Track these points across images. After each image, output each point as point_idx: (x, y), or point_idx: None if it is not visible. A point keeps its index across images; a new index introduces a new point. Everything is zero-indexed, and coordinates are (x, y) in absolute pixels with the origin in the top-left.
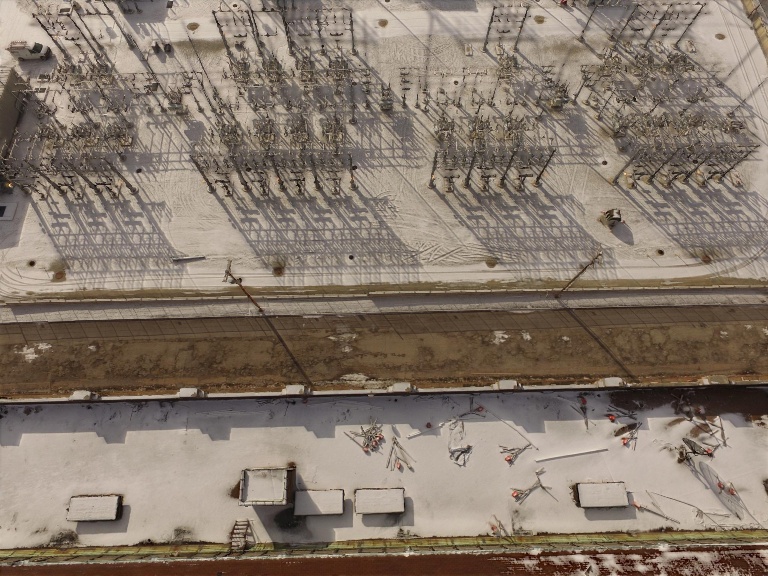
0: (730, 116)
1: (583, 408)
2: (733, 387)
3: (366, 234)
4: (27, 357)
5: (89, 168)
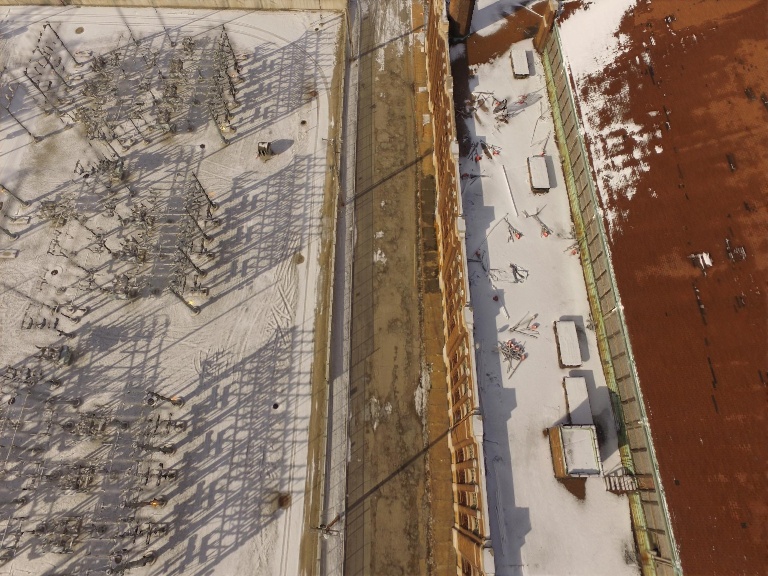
0: (174, 45)
1: (472, 176)
2: None
3: (248, 388)
4: None
5: None
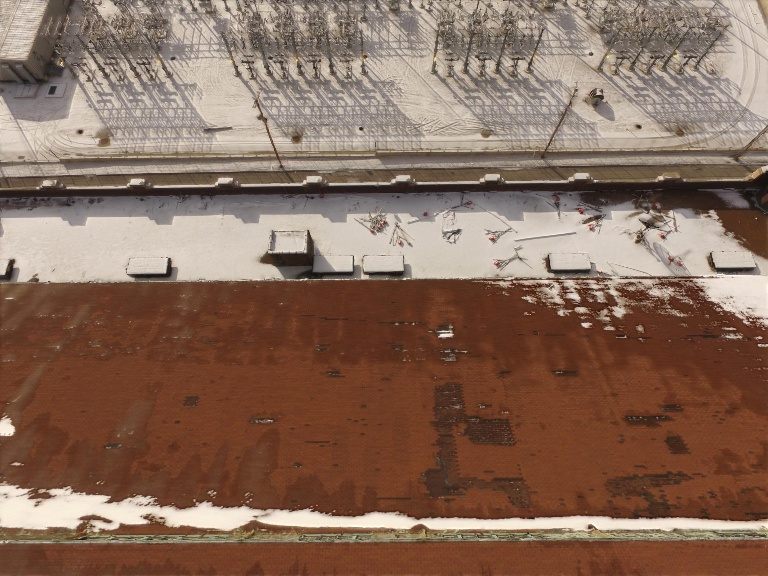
0: (708, 16)
1: (556, 203)
2: (686, 188)
3: (374, 110)
4: None
5: (129, 56)
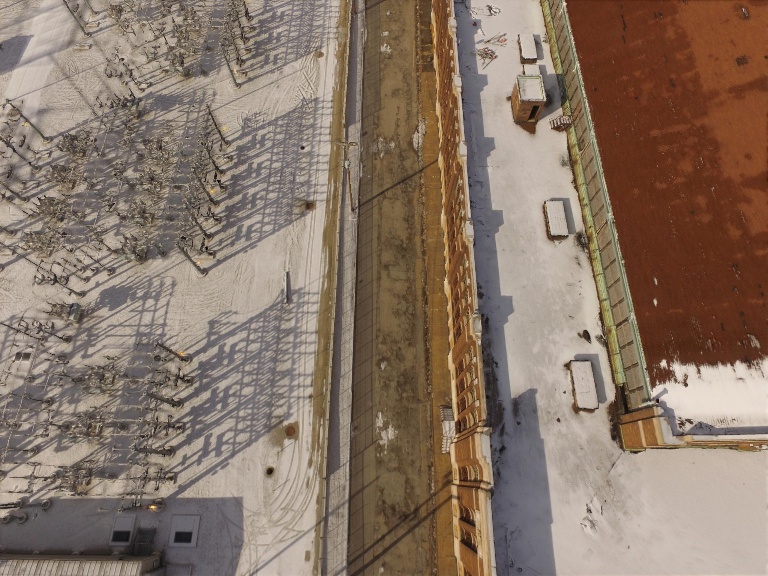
0: None
1: None
2: None
3: (280, 136)
4: (391, 437)
5: None
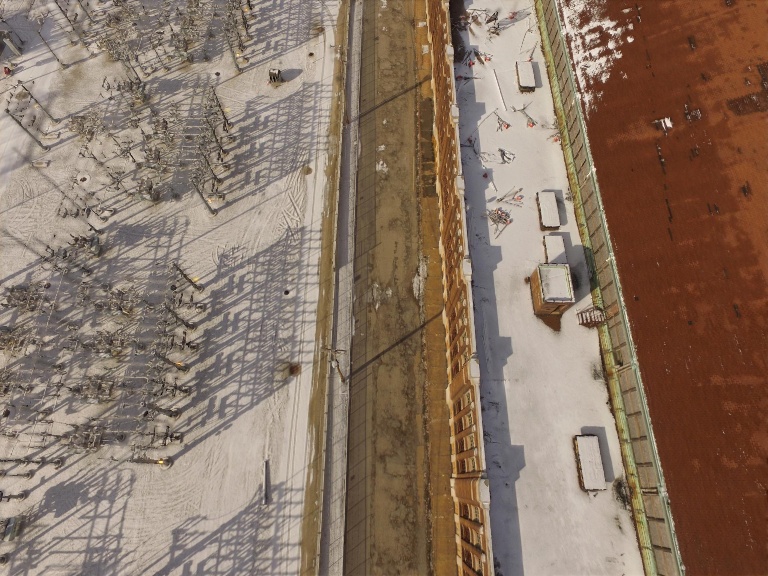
0: None
1: (465, 78)
2: None
3: (261, 277)
4: None
5: None
